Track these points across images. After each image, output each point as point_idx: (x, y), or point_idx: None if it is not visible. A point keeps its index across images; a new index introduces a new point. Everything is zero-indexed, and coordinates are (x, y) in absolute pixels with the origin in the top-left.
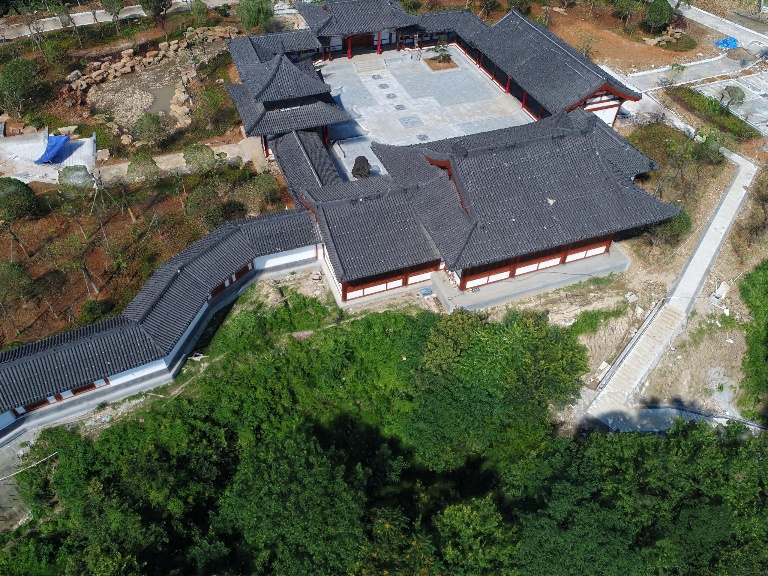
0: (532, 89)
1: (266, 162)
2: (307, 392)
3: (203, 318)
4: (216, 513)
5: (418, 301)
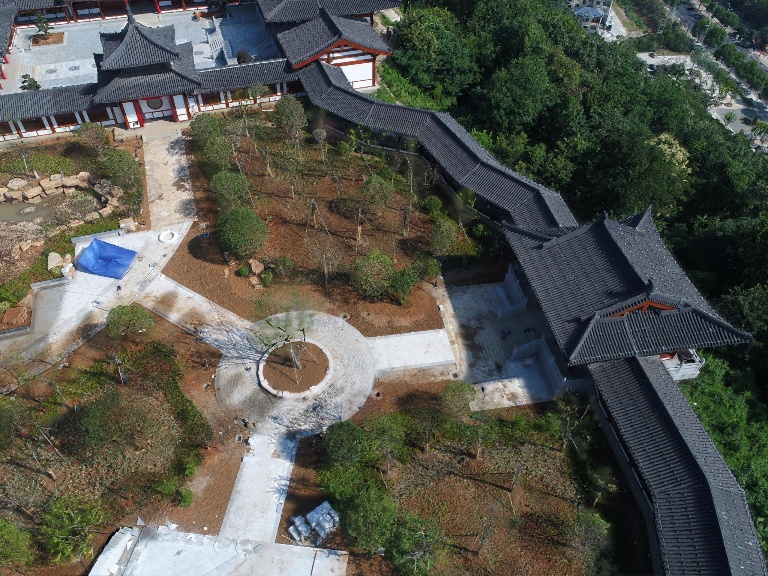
0: None
1: (192, 120)
2: None
3: None
4: None
5: None
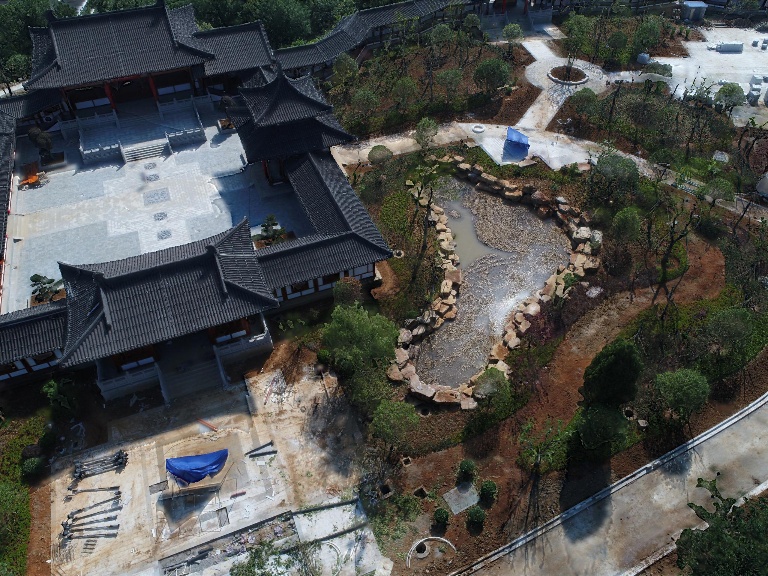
0: (5, 160)
1: None
2: None
3: None
4: None
5: None
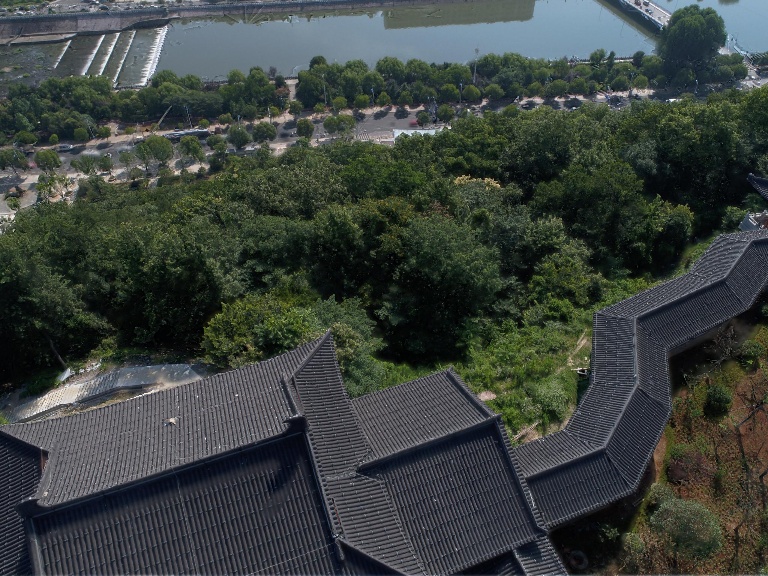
0: None
1: None
2: None
3: None
4: (517, 319)
5: None
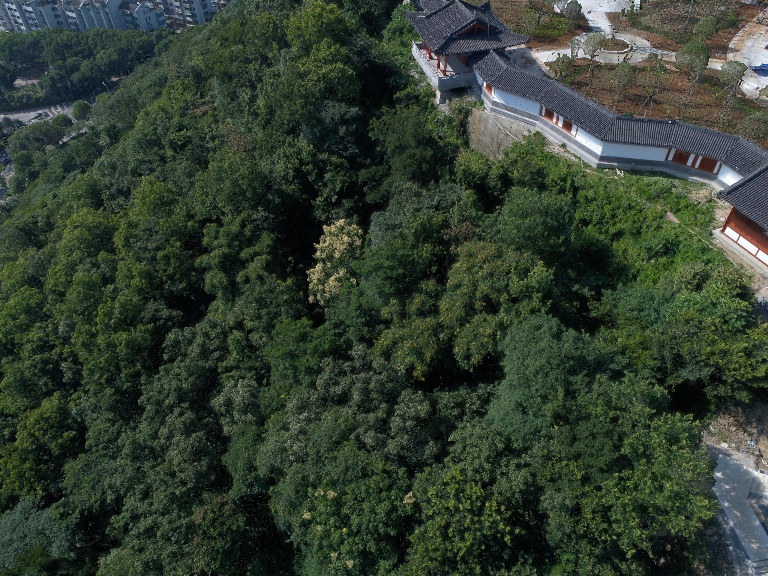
0: None
1: None
2: (629, 244)
3: (652, 164)
4: None
5: (760, 282)
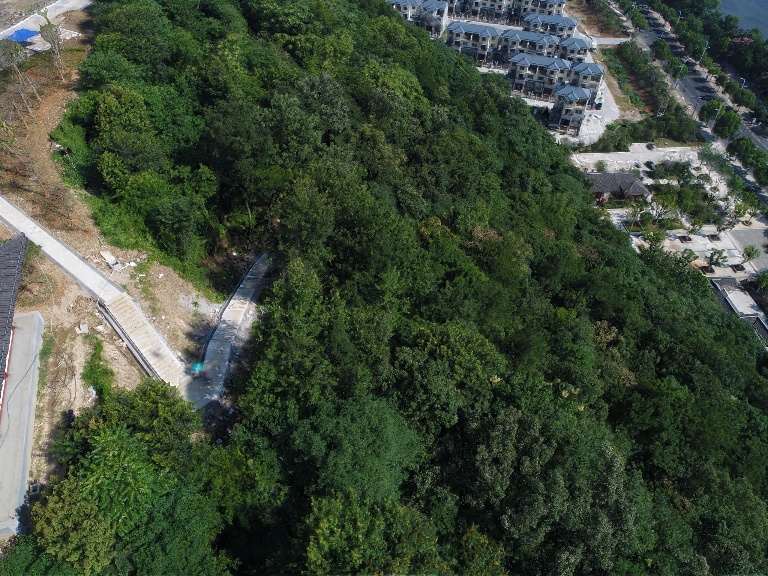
0: None
1: None
2: None
3: None
4: None
5: None
